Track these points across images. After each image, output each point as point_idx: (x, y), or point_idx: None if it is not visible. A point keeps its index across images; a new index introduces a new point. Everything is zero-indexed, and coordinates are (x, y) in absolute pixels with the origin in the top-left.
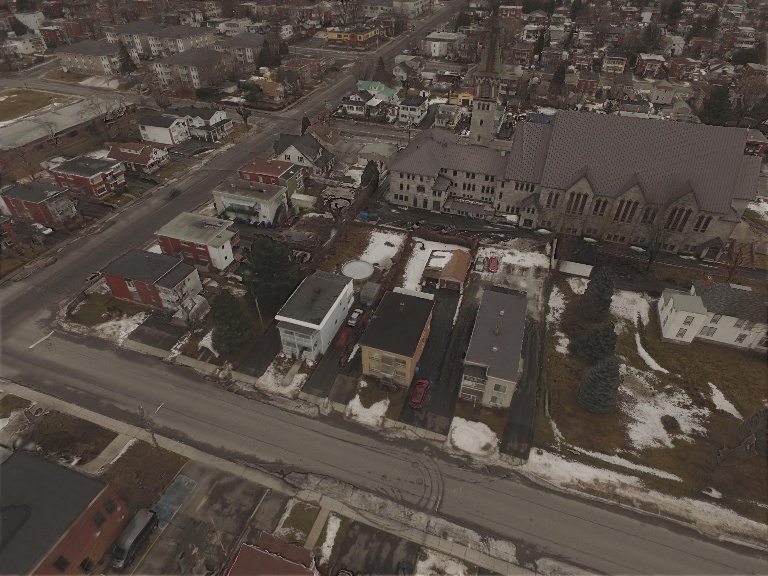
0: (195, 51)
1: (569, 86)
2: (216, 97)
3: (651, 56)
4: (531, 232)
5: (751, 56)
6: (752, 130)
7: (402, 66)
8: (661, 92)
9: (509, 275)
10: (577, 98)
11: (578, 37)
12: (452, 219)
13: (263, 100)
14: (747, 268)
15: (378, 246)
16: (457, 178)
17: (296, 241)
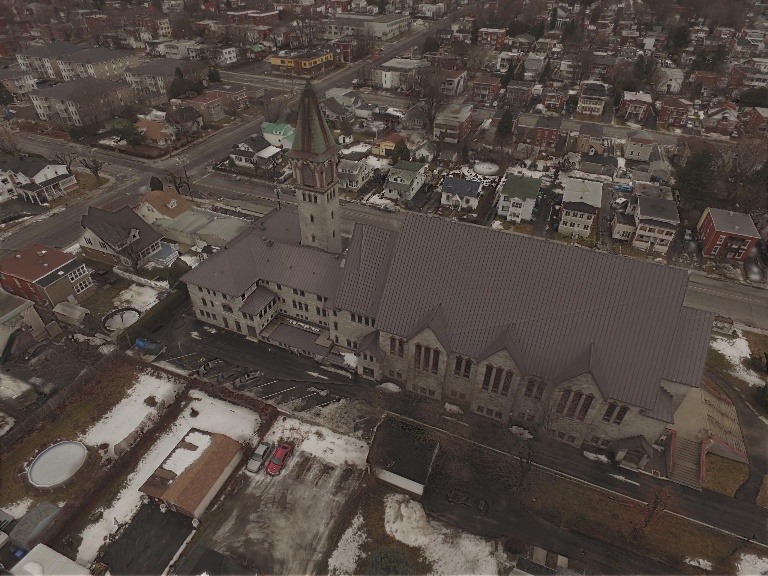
0: (81, 82)
1: (529, 131)
2: (93, 138)
3: (636, 95)
4: (370, 388)
5: (762, 97)
6: (740, 215)
7: (329, 103)
8: (636, 146)
9: (295, 483)
10: (526, 152)
11: (560, 67)
12: (268, 355)
13: (146, 143)
14: (688, 488)
15: (132, 405)
16: (283, 293)
17: (15, 391)
